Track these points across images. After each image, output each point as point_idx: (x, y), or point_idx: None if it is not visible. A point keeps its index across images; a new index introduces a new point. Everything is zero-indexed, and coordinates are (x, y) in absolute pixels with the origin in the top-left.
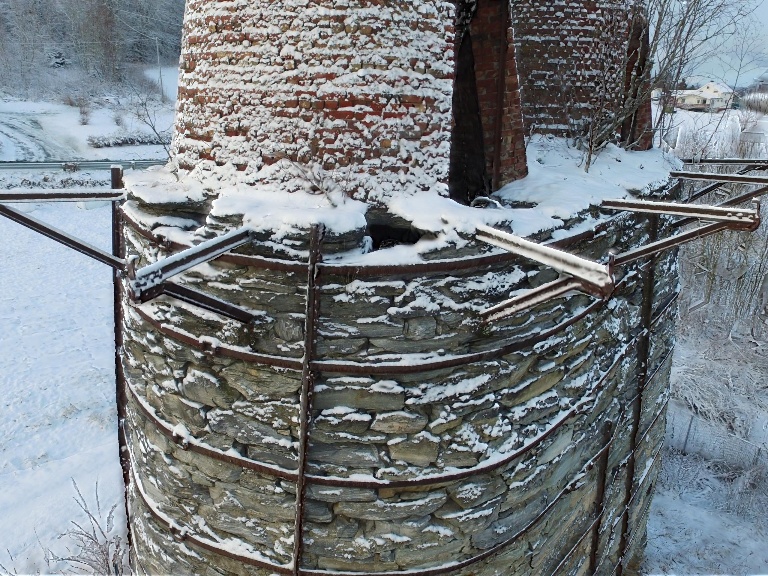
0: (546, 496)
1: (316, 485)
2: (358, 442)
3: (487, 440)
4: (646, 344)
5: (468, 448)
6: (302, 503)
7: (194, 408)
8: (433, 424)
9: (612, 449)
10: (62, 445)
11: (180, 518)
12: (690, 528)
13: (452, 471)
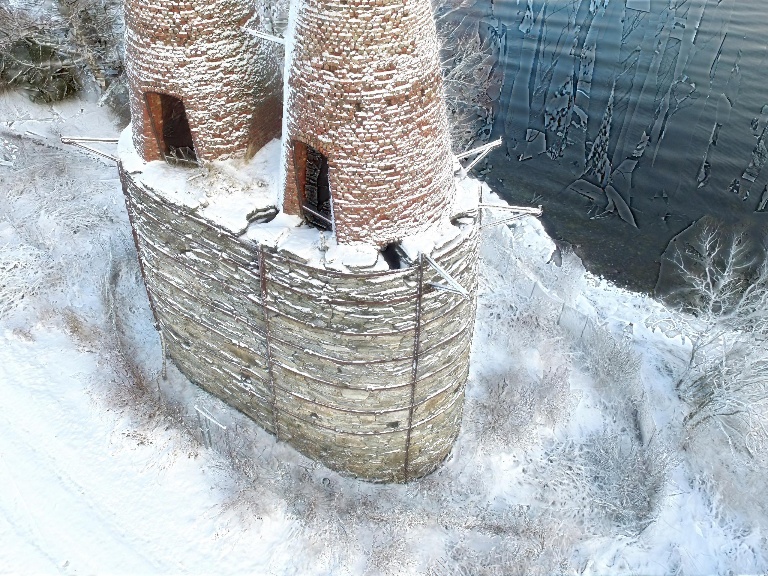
0: None
1: None
2: None
3: None
4: None
5: None
6: None
7: None
8: None
9: None
10: None
11: None
12: None
13: None
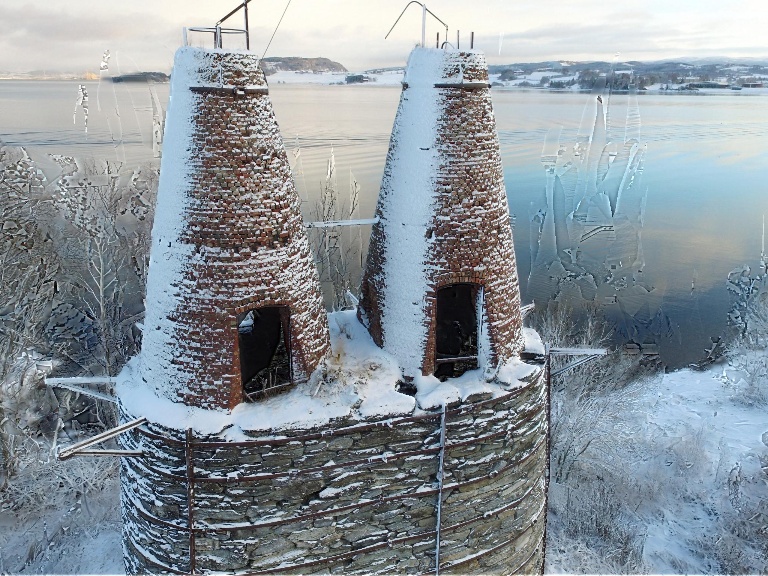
0: None
1: None
2: (473, 363)
3: None
4: None
5: None
6: None
7: None
8: None
9: None
10: None
11: None
12: None
13: None
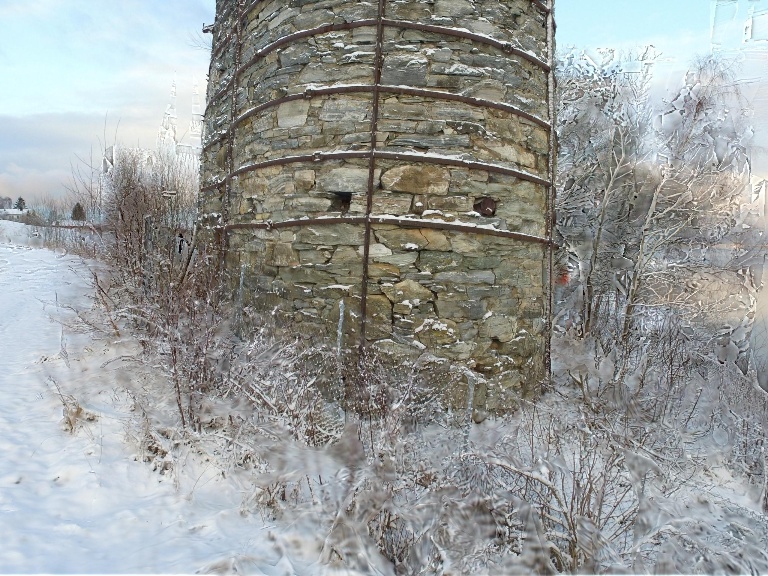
0: None
1: None
2: None
3: None
4: None
5: None
6: None
7: None
8: None
9: None
10: None
11: None
12: None
13: None
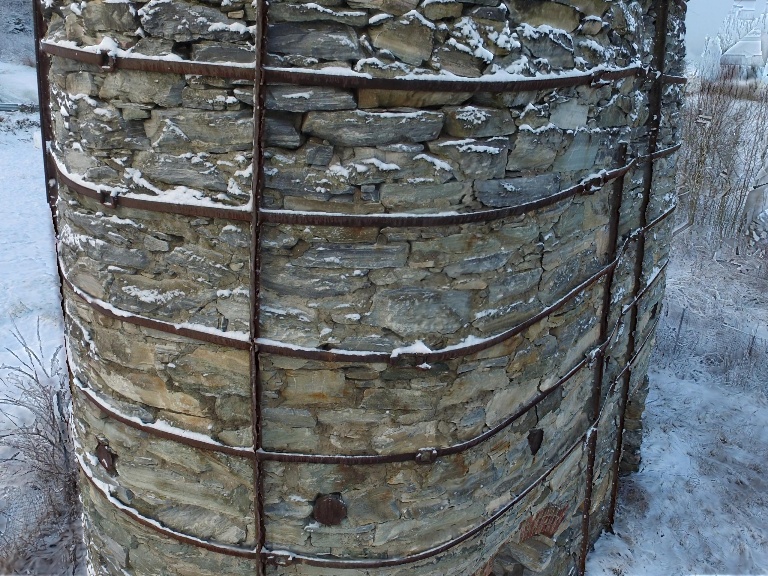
0: (559, 177)
1: (279, 89)
2: (331, 20)
3: (492, 51)
4: (659, 91)
5: (469, 50)
6: (261, 112)
7: (121, 3)
8: (426, 0)
9: (624, 198)
10: (10, 339)
11: (110, 181)
12: (689, 397)
13: (450, 76)
